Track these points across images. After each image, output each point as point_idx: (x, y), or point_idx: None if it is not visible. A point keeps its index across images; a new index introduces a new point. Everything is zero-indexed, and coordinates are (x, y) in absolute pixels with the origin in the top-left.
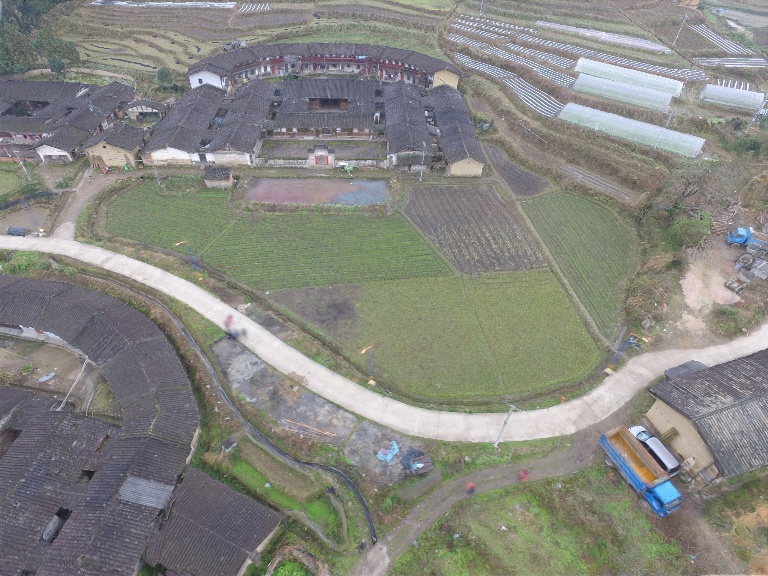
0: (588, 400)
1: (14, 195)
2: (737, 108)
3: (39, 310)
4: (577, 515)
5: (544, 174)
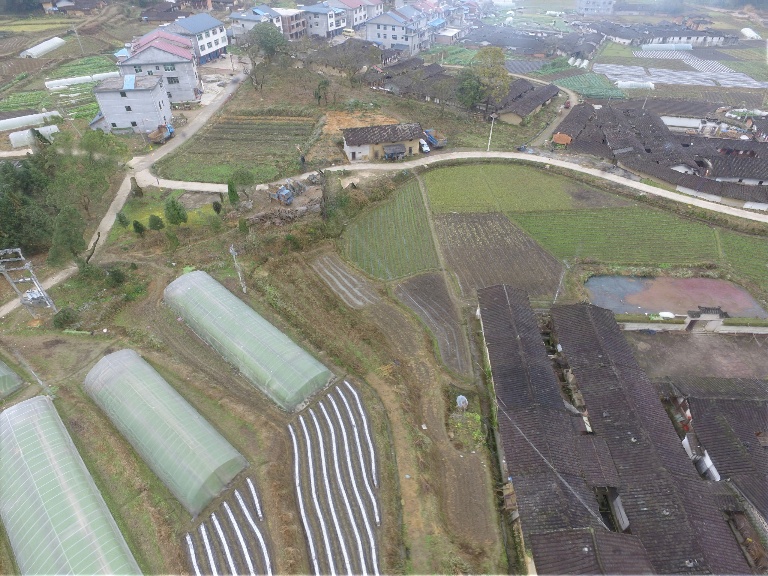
0: (442, 159)
1: None
2: (0, 349)
3: (763, 186)
4: (460, 138)
5: (396, 303)
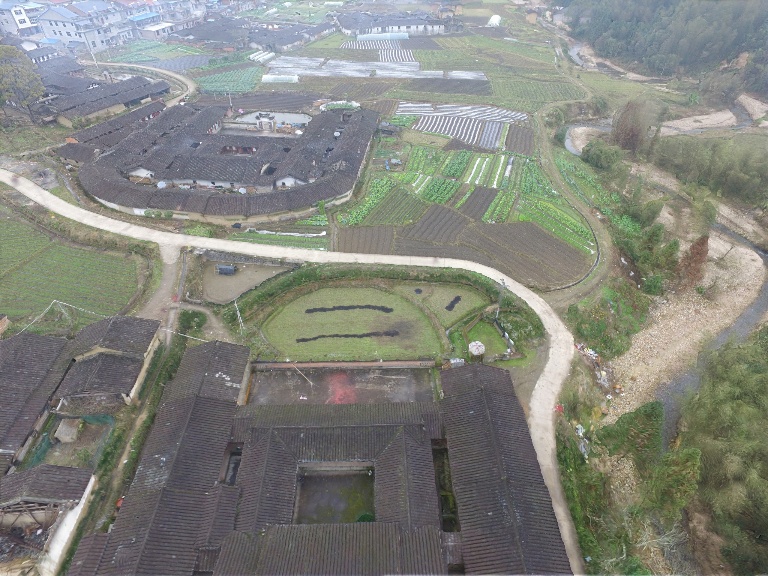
0: None
1: (247, 300)
2: None
3: None
4: None
5: None
